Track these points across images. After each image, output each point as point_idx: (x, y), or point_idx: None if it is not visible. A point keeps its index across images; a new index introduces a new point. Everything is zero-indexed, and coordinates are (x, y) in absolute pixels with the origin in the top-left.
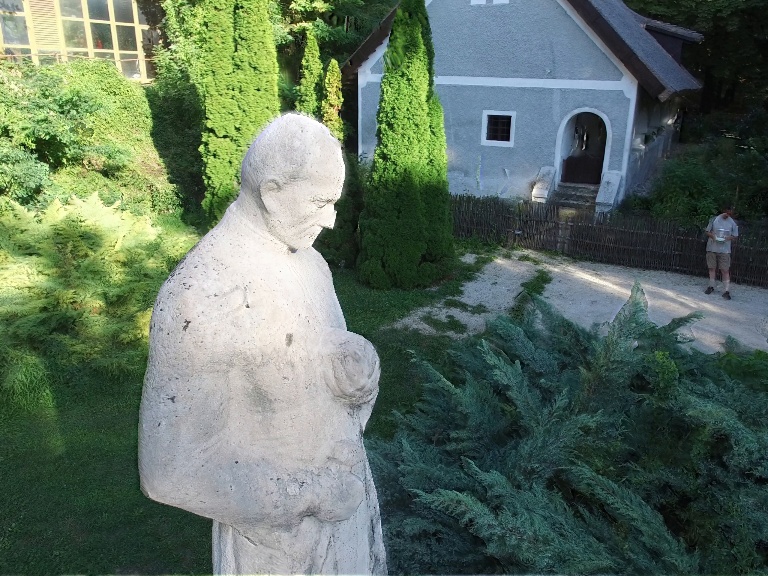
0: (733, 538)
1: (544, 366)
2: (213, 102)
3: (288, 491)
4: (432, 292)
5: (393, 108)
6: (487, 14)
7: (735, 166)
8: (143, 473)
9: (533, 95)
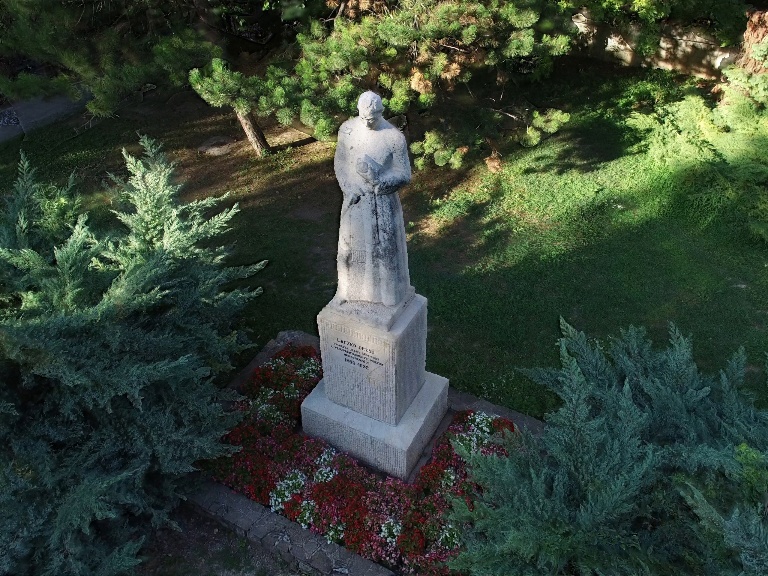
0: None
1: None
2: None
3: None
4: None
5: None
6: None
7: None
8: None
9: None
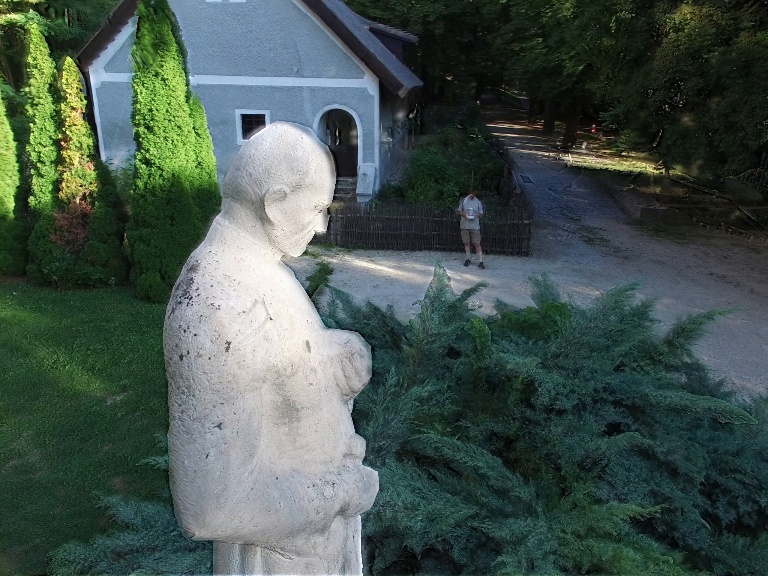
0: (560, 462)
1: None
2: None
3: (326, 495)
4: None
5: (151, 110)
6: (227, 12)
7: (468, 153)
8: (190, 513)
9: (284, 93)
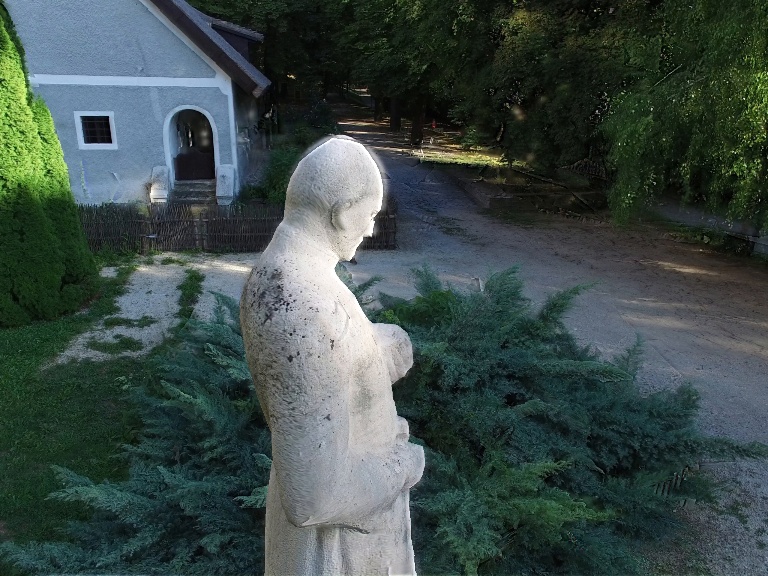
0: (478, 434)
1: None
2: None
3: (396, 471)
4: (85, 315)
5: None
6: (56, 5)
7: None
8: (304, 500)
9: (128, 94)
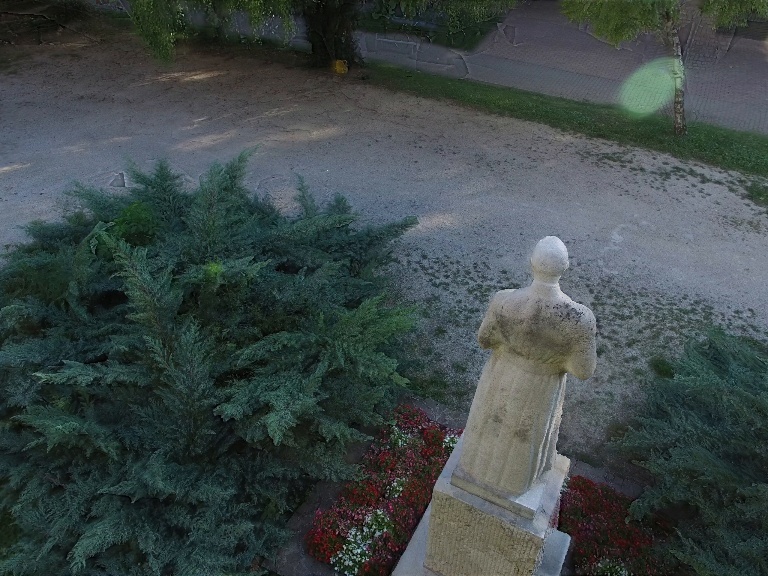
0: None
1: (35, 354)
2: None
3: None
4: None
5: None
6: None
7: None
8: None
9: None
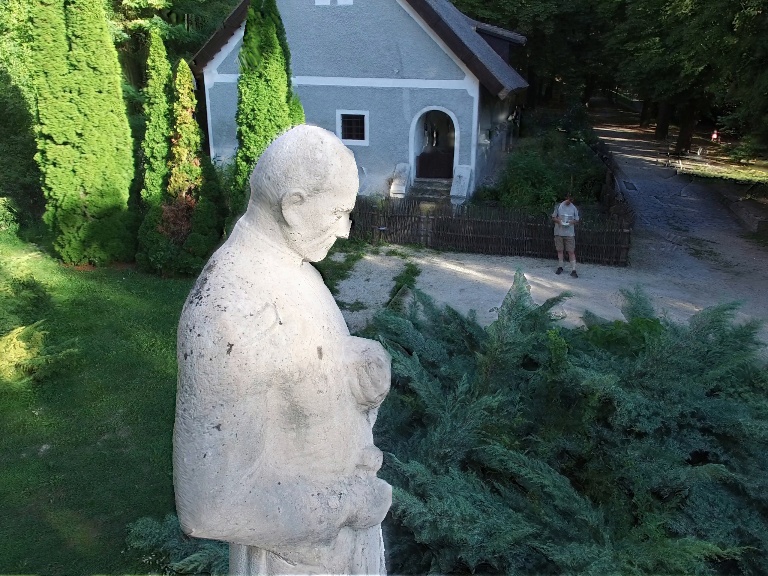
0: (632, 488)
1: (436, 355)
2: (48, 106)
3: (330, 503)
4: None
5: (253, 109)
6: (333, 15)
7: (568, 157)
8: (187, 508)
9: (384, 94)
